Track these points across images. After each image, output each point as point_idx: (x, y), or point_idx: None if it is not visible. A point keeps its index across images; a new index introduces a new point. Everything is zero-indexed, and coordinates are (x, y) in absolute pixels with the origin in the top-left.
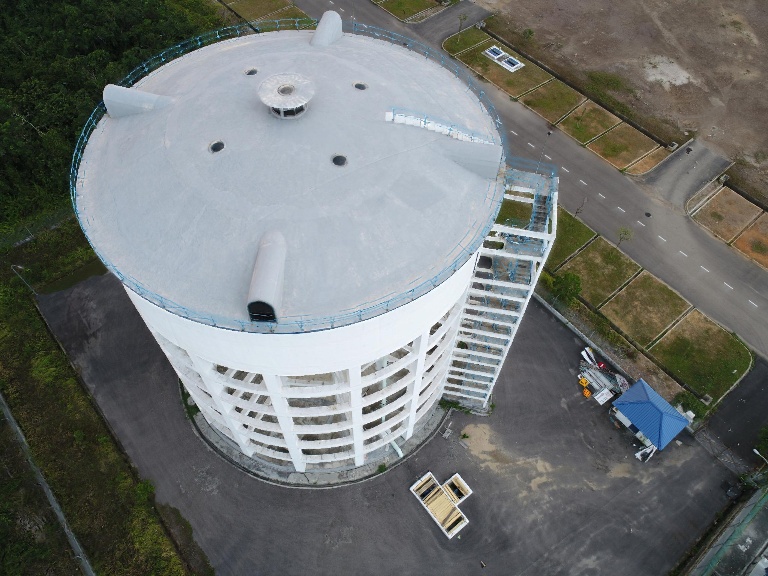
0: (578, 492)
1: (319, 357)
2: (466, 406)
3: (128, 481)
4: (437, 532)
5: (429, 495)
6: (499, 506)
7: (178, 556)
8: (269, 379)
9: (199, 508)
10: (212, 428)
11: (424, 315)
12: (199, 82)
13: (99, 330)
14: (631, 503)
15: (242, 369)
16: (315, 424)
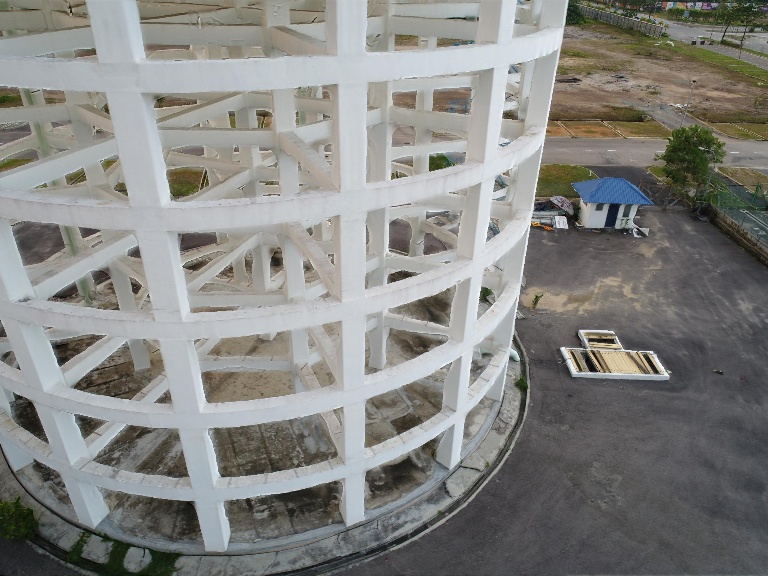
0: (657, 277)
1: None
2: None
3: None
4: (652, 385)
5: (595, 363)
6: (643, 326)
7: None
8: None
9: None
10: (239, 553)
11: None
12: None
13: None
14: (687, 259)
15: None
16: (389, 408)
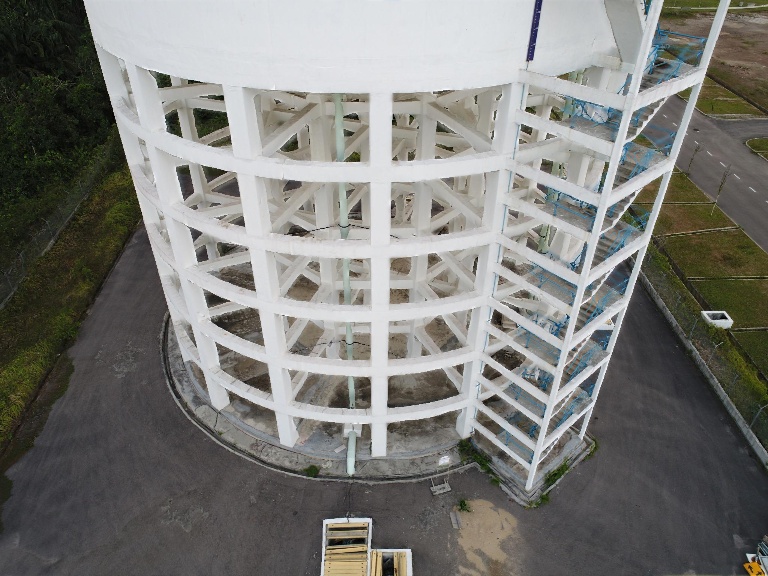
0: None
1: (174, 15)
2: (500, 473)
3: (67, 318)
4: None
5: (342, 548)
6: None
7: (23, 410)
8: (133, 79)
9: (91, 380)
10: None
11: (370, 21)
12: None
13: None
14: None
15: (110, 47)
16: None
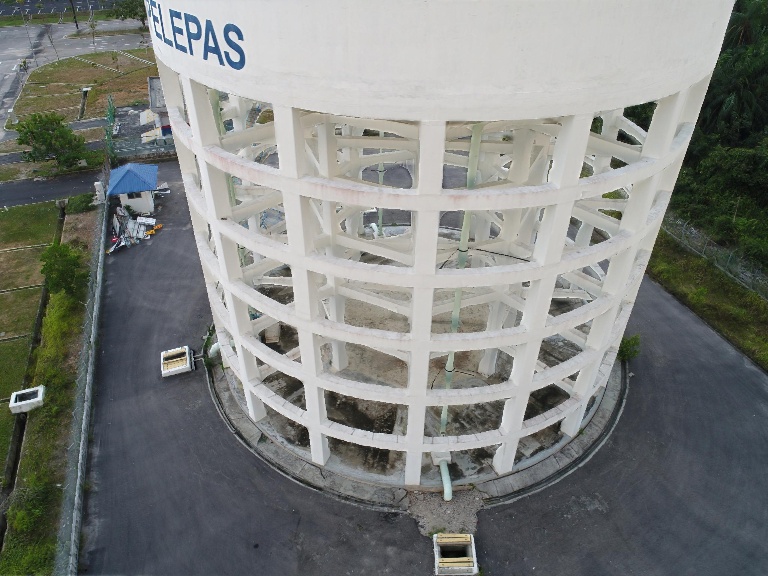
0: None
1: None
2: None
3: None
4: None
5: None
6: None
7: None
8: None
9: None
10: None
11: None
12: None
13: None
14: None
15: None
16: None
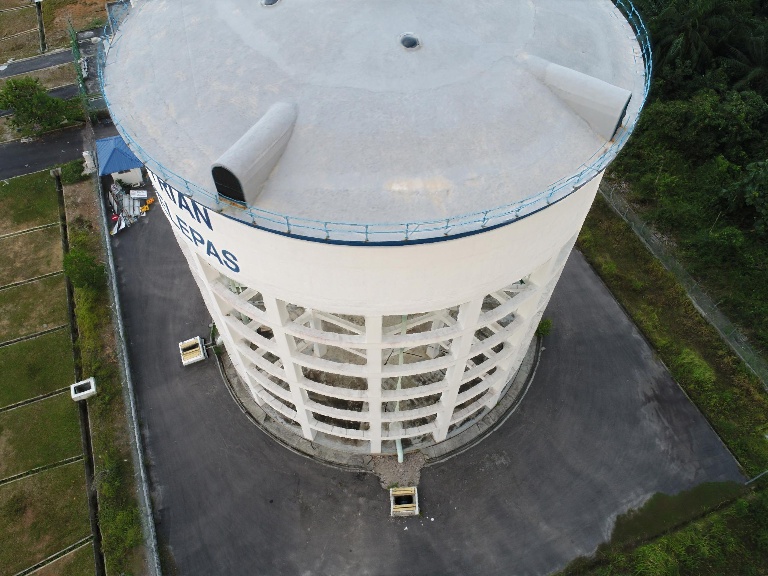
0: None
1: None
2: None
3: None
4: None
5: None
6: None
7: None
8: None
9: None
10: None
11: None
12: (488, 68)
13: (643, 403)
14: None
15: None
16: None
